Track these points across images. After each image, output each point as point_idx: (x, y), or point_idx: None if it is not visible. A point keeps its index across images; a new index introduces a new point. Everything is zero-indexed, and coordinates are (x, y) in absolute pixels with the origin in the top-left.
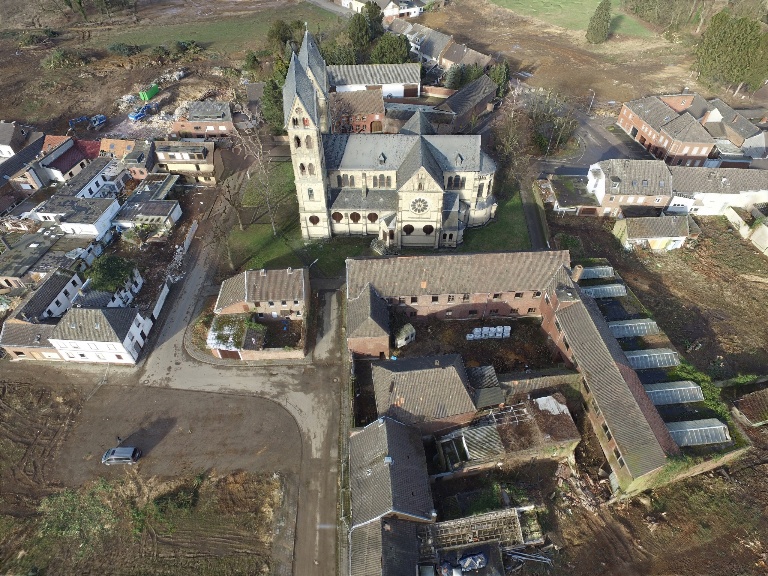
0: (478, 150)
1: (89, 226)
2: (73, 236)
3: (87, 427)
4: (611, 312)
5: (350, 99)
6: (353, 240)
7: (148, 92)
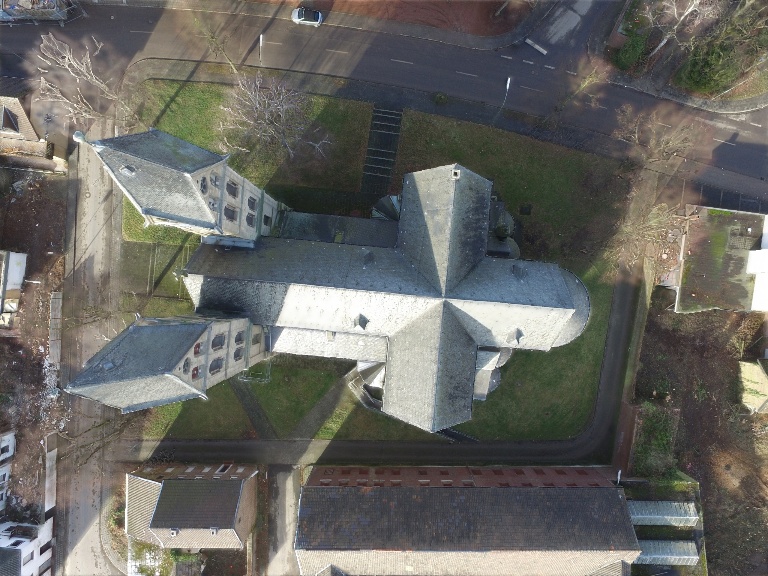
0: (559, 328)
1: None
2: None
3: None
4: None
5: None
6: (317, 357)
7: None
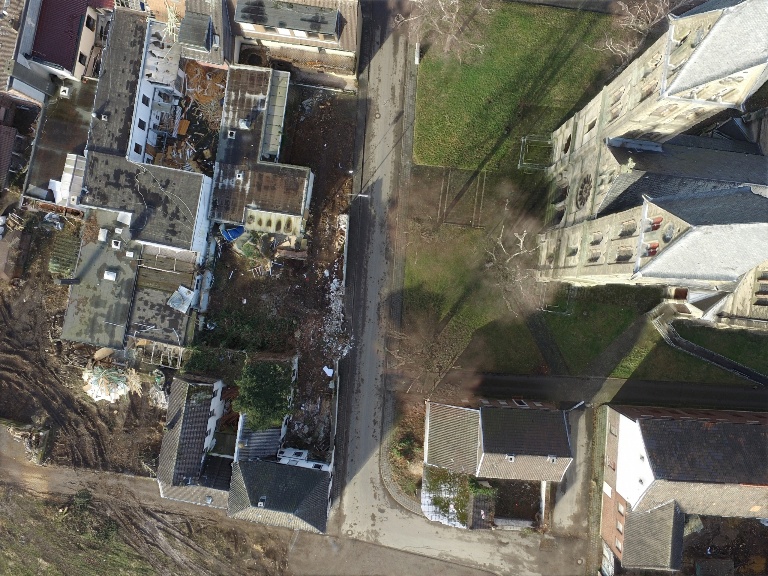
0: None
1: (184, 250)
2: (159, 251)
3: None
4: None
5: None
6: (618, 292)
7: None
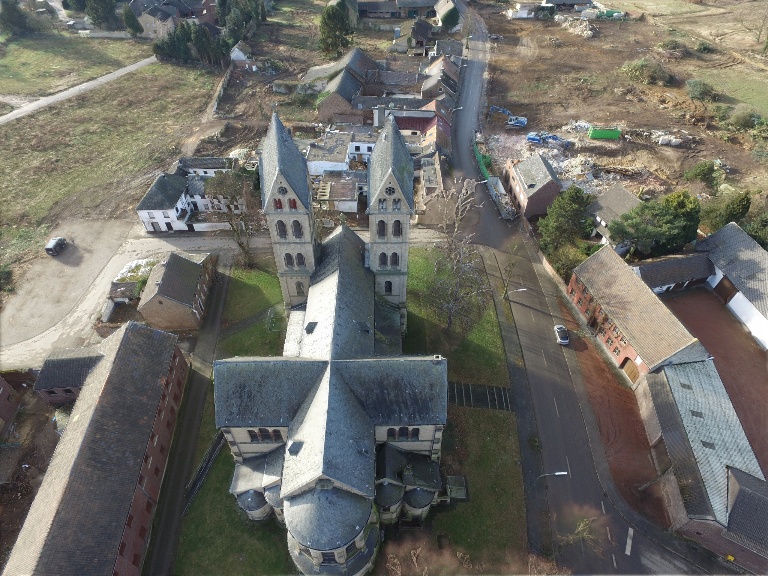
0: (304, 479)
1: None
2: None
3: (97, 226)
4: None
5: (639, 301)
6: None
7: (598, 131)
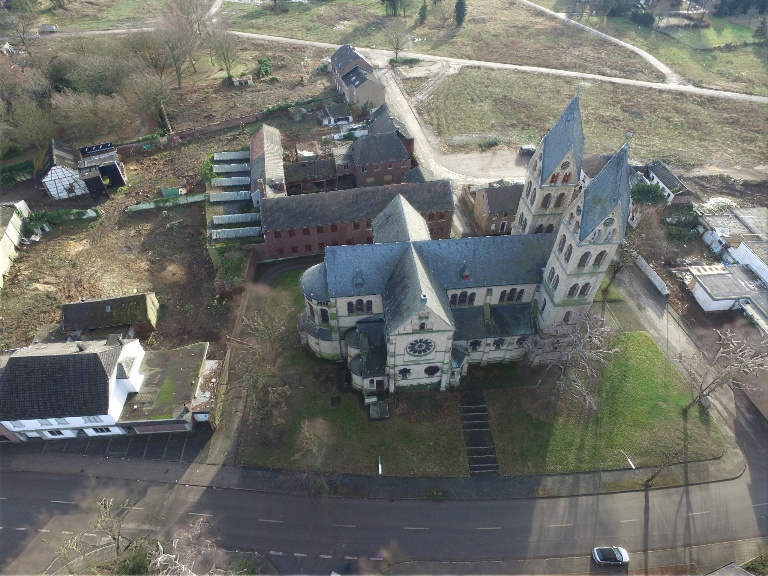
0: None
1: None
2: None
3: None
4: (235, 207)
5: None
6: None
7: None
